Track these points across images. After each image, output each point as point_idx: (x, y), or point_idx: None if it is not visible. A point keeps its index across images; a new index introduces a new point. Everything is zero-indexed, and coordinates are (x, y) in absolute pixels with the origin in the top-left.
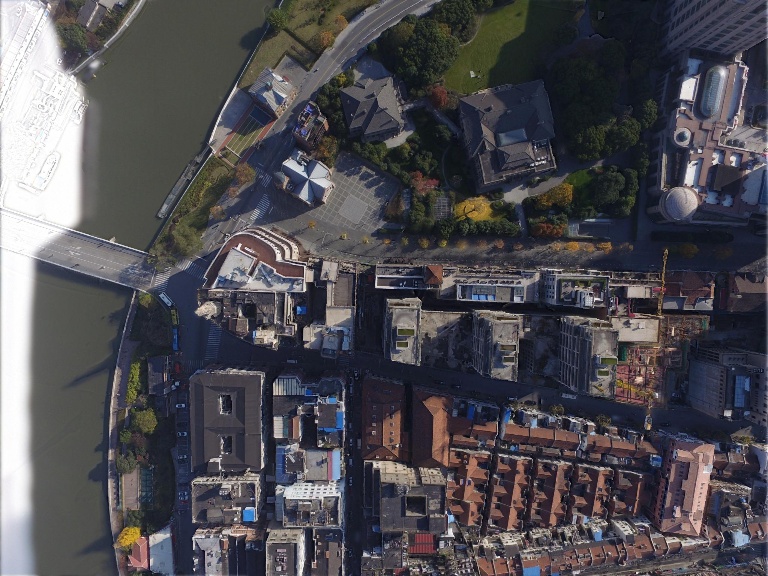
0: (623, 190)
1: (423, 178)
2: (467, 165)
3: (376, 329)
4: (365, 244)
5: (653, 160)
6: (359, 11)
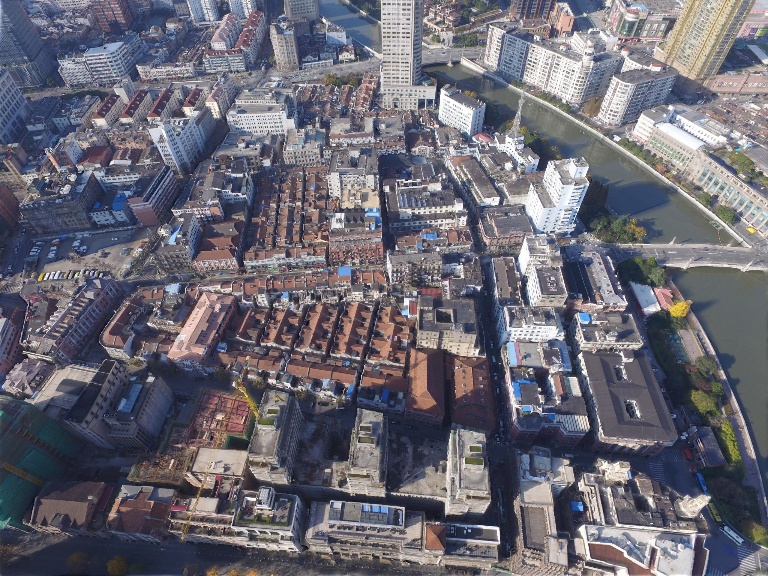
0: None
1: None
2: None
3: None
4: None
5: None
6: None
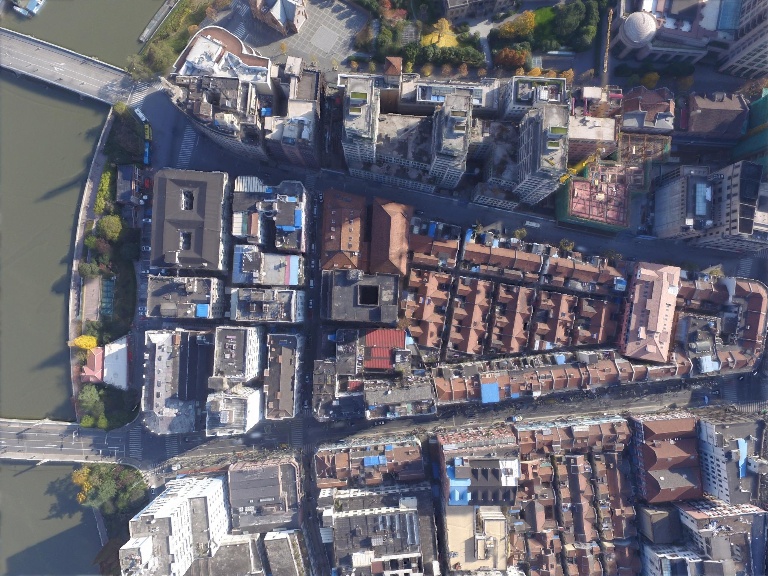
0: (584, 21)
1: (392, 11)
2: (434, 0)
3: (342, 153)
4: (334, 72)
5: None
6: None
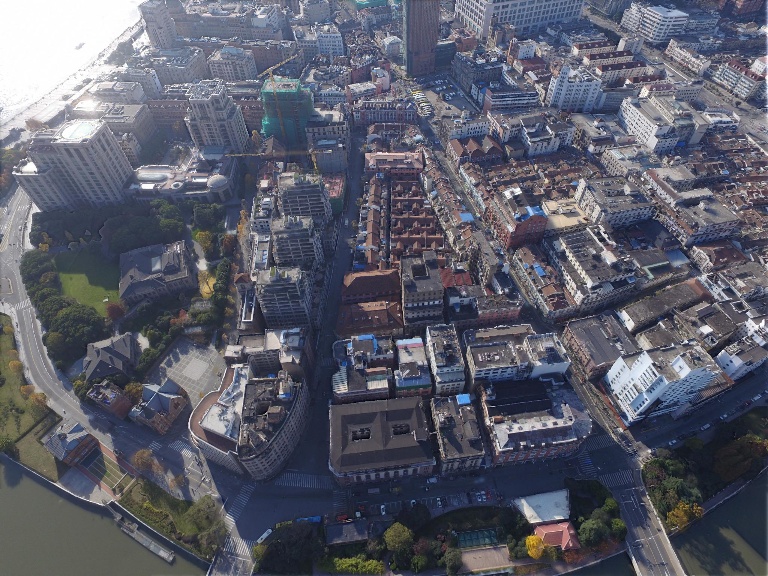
0: None
1: None
2: (174, 295)
3: None
4: None
5: None
6: (25, 382)
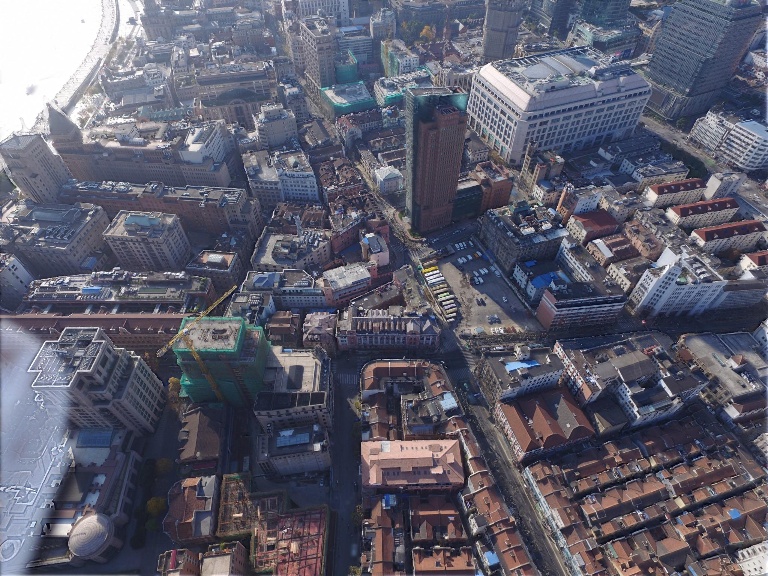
0: None
1: None
2: None
3: None
4: None
5: (39, 571)
6: None
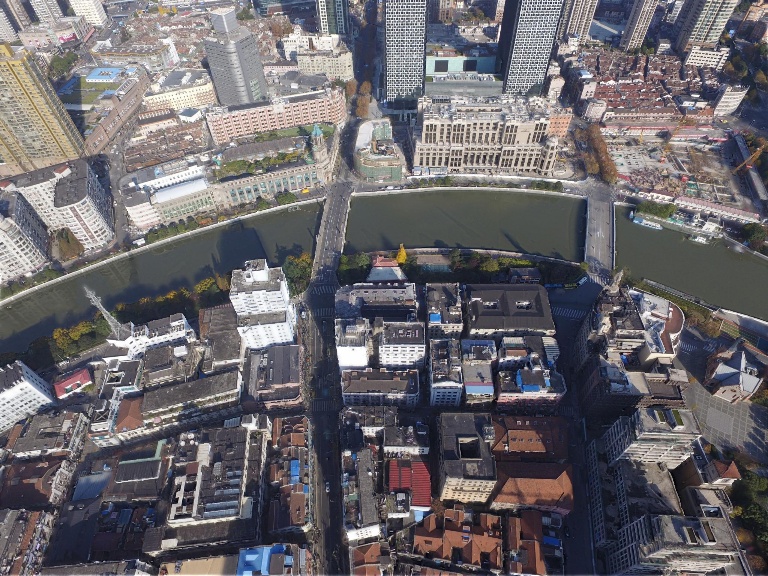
0: None
1: None
2: None
3: None
4: None
5: None
6: None
